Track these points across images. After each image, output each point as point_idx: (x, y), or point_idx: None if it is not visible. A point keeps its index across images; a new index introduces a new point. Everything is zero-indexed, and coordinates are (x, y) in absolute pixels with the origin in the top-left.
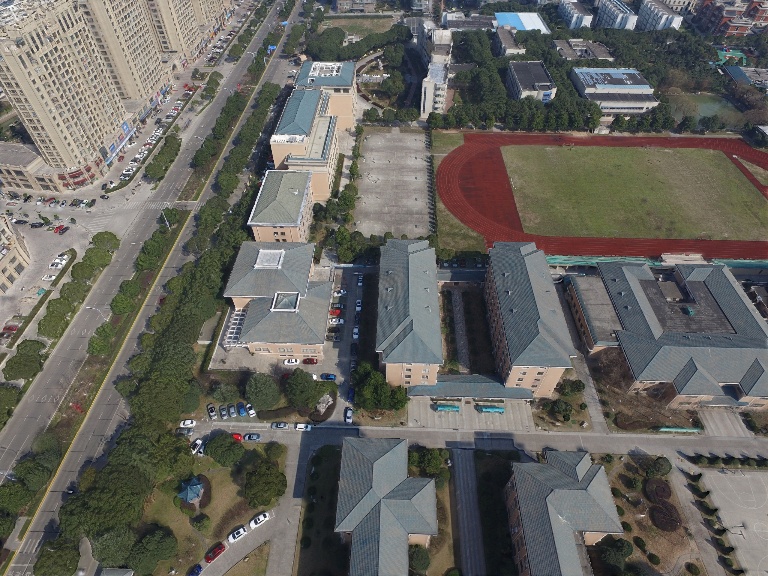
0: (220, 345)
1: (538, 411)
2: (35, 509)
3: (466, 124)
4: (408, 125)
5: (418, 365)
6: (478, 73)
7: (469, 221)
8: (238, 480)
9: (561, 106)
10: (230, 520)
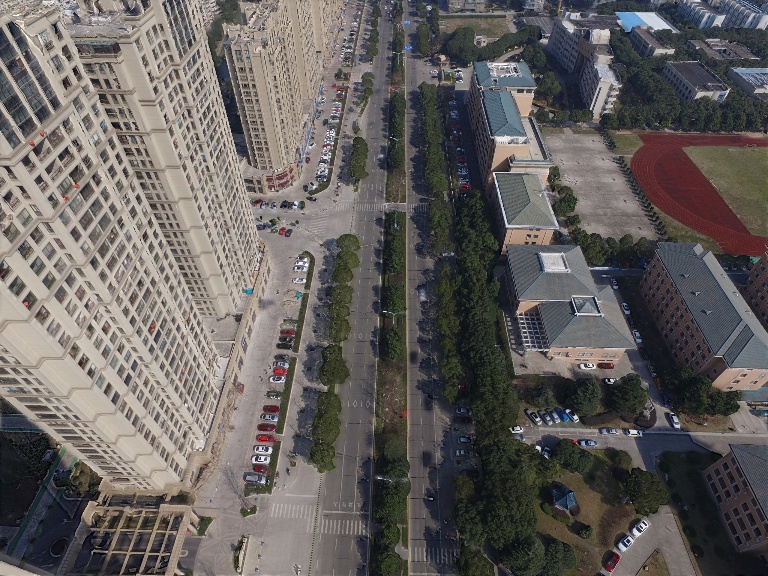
0: (512, 349)
1: None
2: (405, 516)
3: (641, 125)
4: (578, 126)
5: (758, 370)
6: (636, 73)
7: (690, 223)
8: (595, 487)
9: (739, 107)
10: (609, 528)
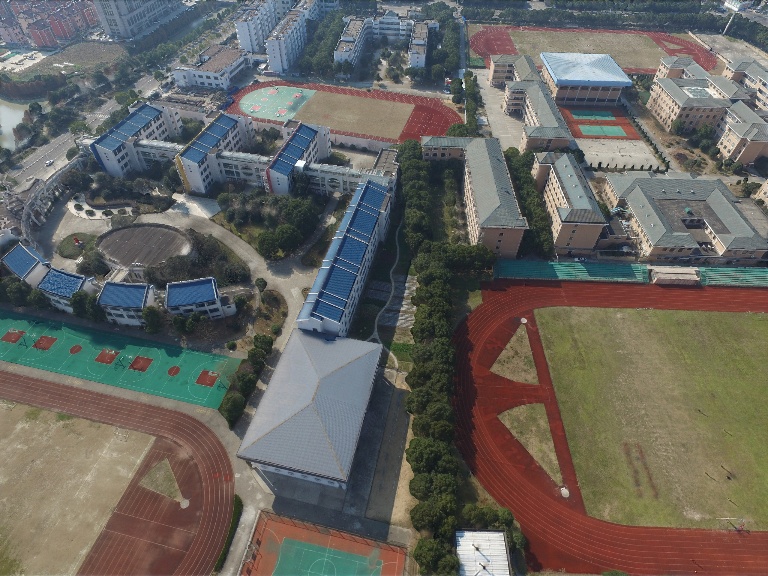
0: None
1: None
2: None
3: None
4: None
5: None
6: None
7: None
8: None
9: None
10: None
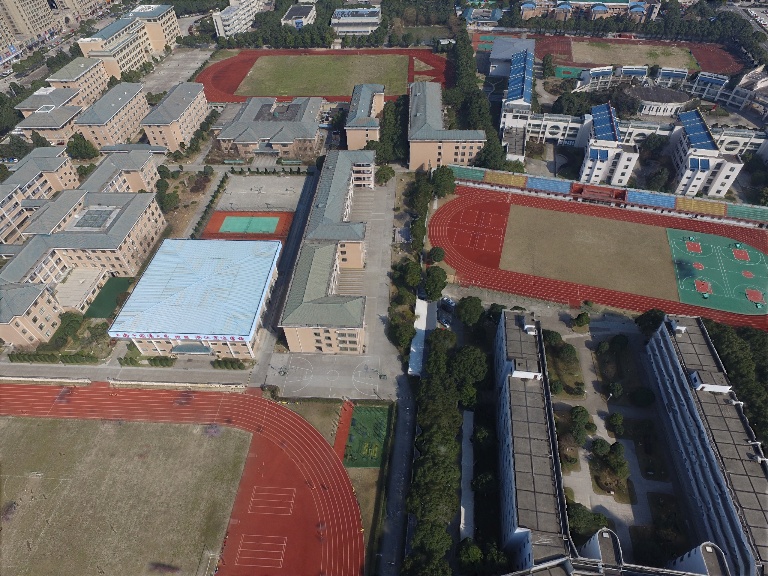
0: None
1: (169, 159)
2: None
3: (242, 44)
4: (208, 47)
5: (95, 127)
6: None
7: (203, 90)
8: None
9: (306, 30)
10: None
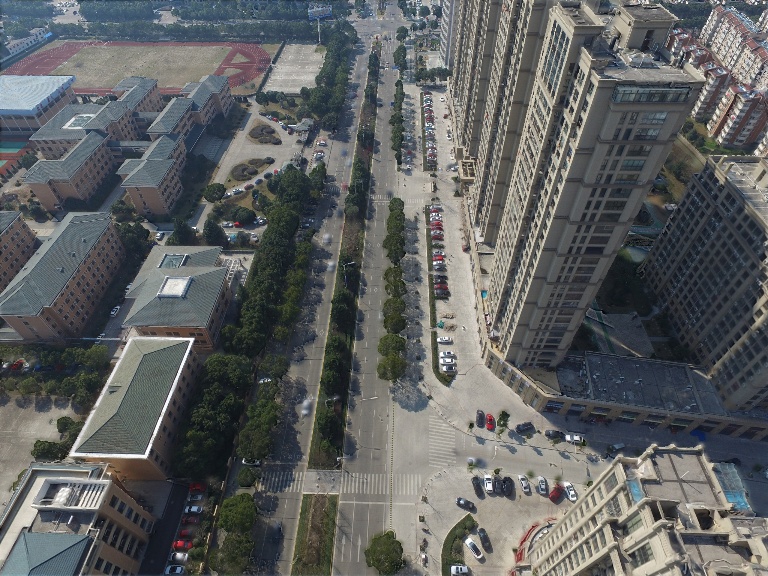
0: None
1: None
2: None
3: None
4: None
5: None
6: None
7: None
8: None
9: None
10: (242, 196)
